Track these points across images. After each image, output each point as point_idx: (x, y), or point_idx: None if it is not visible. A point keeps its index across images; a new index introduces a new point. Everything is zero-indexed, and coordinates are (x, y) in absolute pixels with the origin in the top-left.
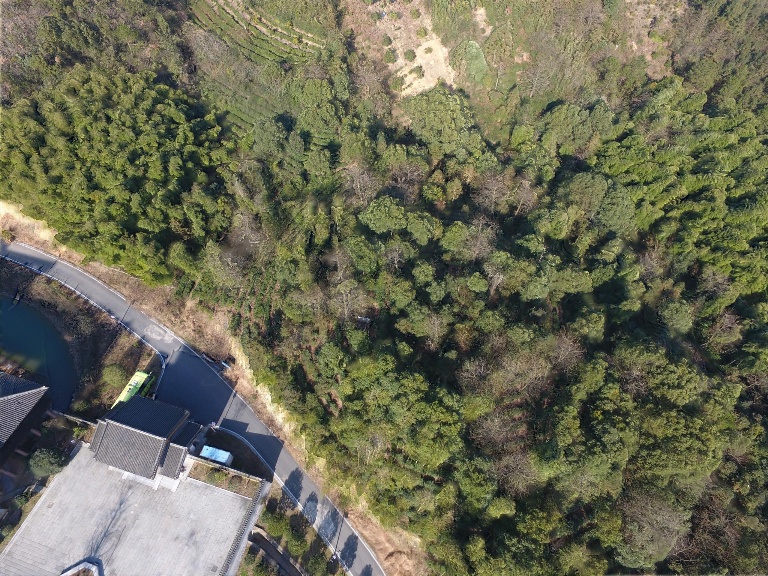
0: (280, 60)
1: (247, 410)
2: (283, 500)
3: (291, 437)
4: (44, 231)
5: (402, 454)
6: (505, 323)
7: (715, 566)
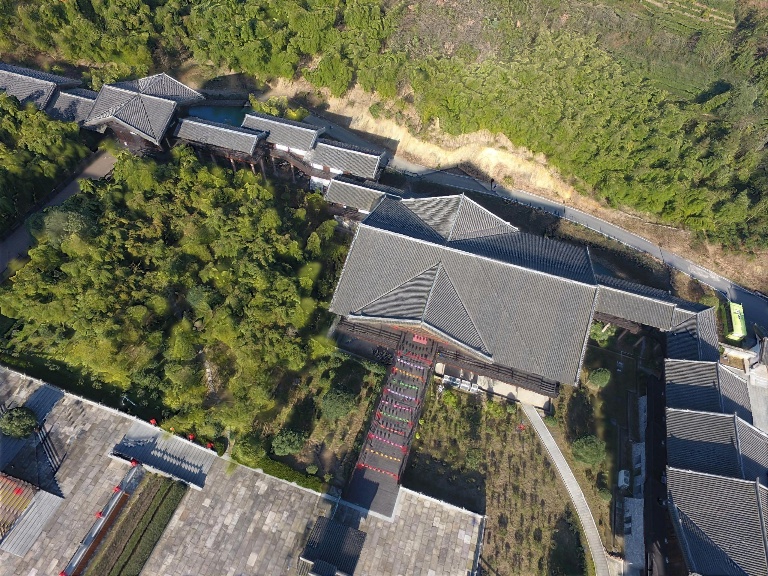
0: (695, 32)
1: None
2: None
3: None
4: (543, 180)
5: None
6: None
7: None
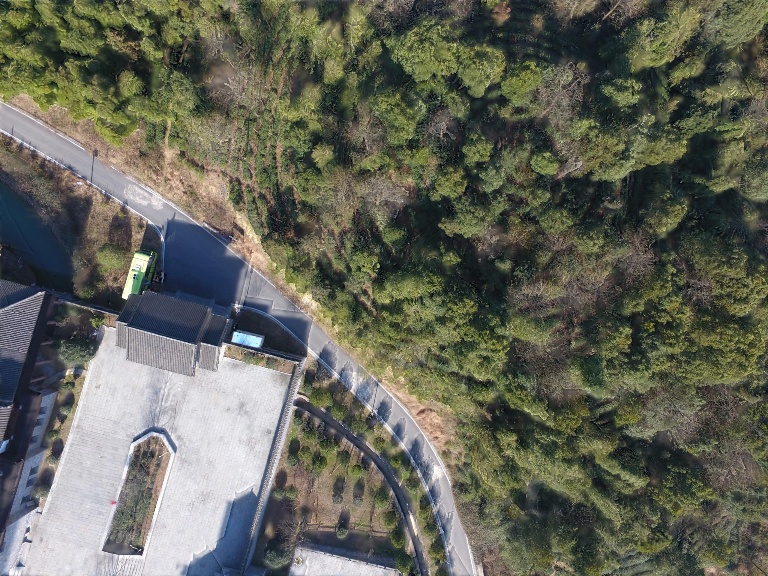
0: None
1: (268, 286)
2: (320, 371)
3: (320, 314)
4: None
5: (438, 345)
6: (572, 225)
7: (707, 437)
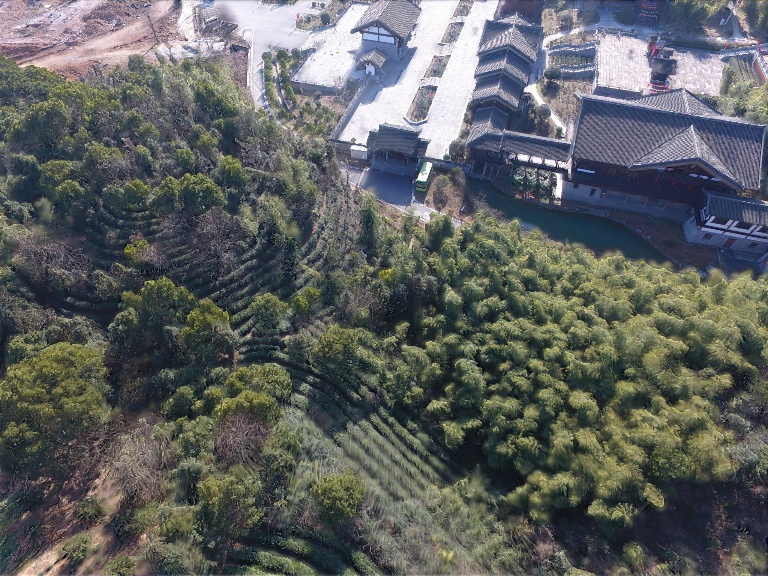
0: None
1: None
2: None
3: None
4: None
5: None
6: None
7: None
